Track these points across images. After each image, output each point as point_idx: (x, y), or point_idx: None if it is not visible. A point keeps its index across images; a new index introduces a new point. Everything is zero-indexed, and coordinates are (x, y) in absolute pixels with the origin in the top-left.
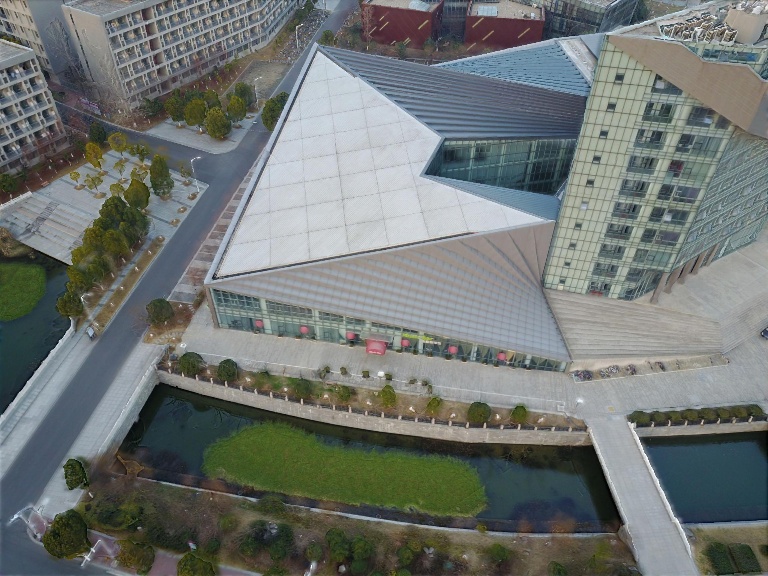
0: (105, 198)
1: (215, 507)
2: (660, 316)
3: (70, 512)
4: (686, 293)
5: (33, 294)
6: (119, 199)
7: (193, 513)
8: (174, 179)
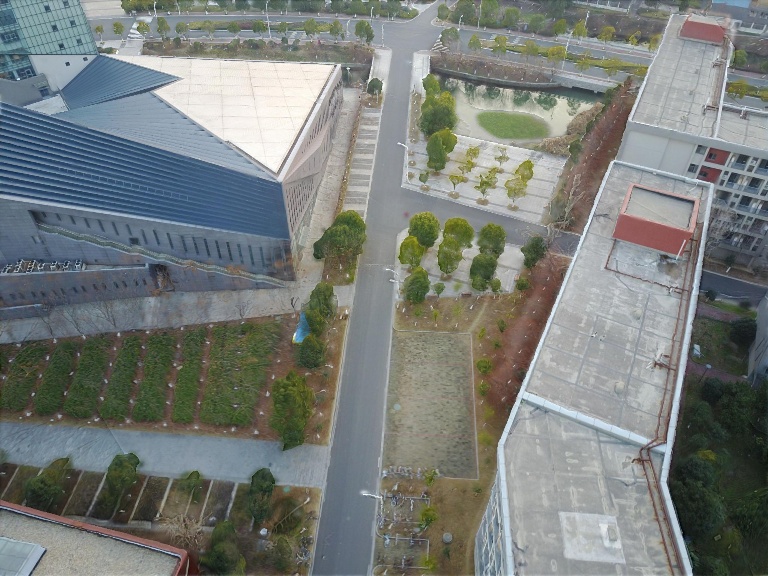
0: (491, 168)
1: None
2: None
3: (362, 24)
4: None
5: (485, 123)
6: (440, 106)
7: None
8: (441, 191)
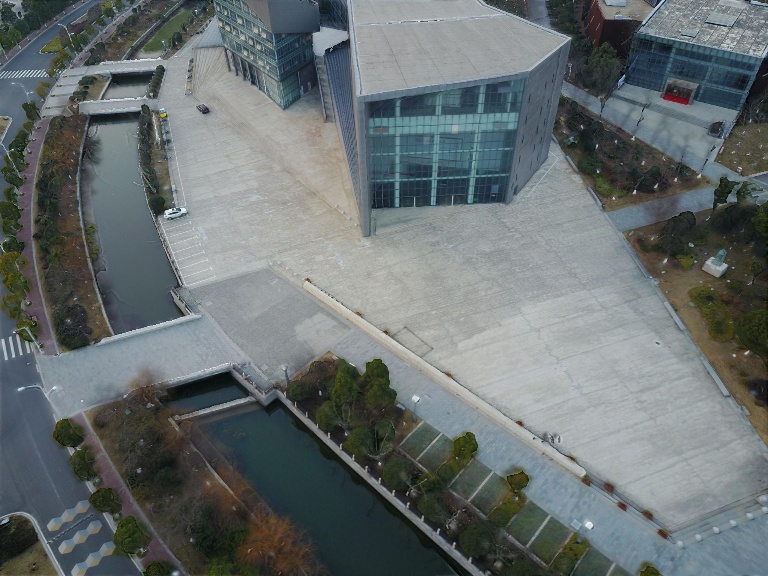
0: None
1: (160, 6)
2: (220, 73)
3: None
4: (235, 80)
5: None
6: None
7: (160, 4)
8: None
